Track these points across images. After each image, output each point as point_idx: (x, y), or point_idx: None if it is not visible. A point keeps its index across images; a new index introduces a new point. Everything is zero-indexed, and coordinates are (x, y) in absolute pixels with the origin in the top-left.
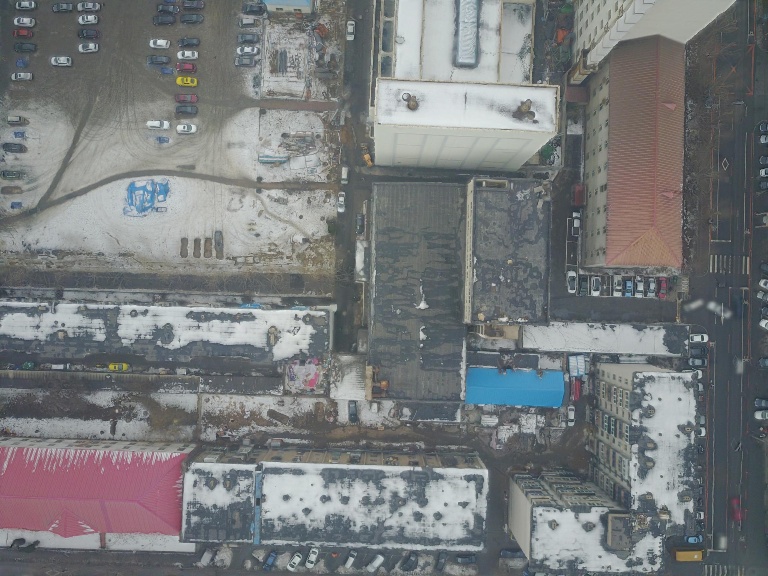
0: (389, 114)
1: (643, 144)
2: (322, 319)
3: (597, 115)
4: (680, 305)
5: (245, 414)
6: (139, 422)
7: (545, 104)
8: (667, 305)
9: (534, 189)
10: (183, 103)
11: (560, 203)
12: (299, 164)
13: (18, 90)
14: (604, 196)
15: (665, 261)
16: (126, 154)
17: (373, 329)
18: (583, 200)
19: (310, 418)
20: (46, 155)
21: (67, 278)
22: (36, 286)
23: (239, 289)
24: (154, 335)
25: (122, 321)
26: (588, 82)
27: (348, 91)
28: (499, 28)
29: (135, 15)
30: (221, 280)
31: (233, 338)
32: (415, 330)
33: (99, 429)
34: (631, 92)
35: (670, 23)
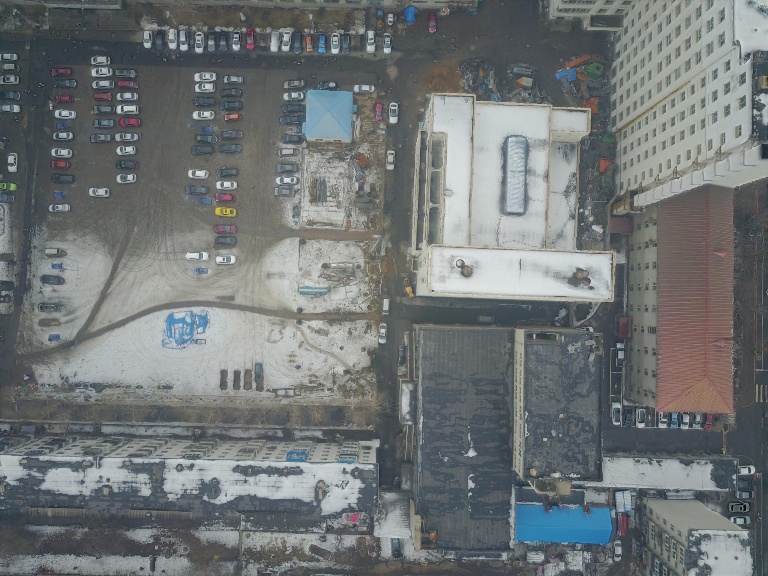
0: (443, 281)
1: (694, 293)
2: (371, 472)
3: (642, 251)
4: (726, 436)
5: (287, 550)
6: (179, 558)
7: (600, 270)
8: (713, 436)
9: (585, 342)
10: (222, 233)
11: (603, 333)
12: (339, 295)
13: (55, 221)
14: (653, 339)
15: (716, 408)
16: (165, 285)
17: (420, 476)
18: (627, 332)
19: (352, 553)
20: (84, 287)
21: (105, 411)
22: (74, 420)
23: (279, 422)
24: (200, 490)
25: (168, 475)
26: (631, 213)
27: (388, 220)
28: (547, 175)
29: (173, 145)
30: (261, 413)
31: (280, 492)
32: (463, 478)
33: (138, 565)
34: (680, 239)
35: (722, 178)
